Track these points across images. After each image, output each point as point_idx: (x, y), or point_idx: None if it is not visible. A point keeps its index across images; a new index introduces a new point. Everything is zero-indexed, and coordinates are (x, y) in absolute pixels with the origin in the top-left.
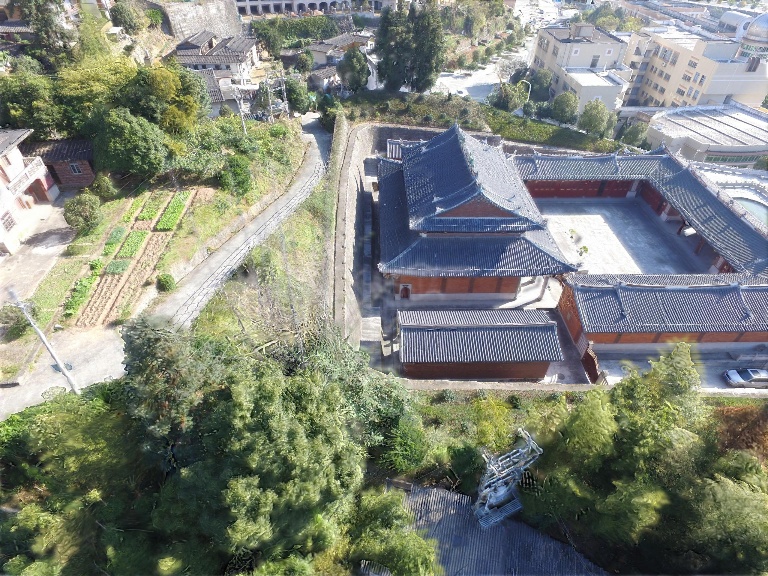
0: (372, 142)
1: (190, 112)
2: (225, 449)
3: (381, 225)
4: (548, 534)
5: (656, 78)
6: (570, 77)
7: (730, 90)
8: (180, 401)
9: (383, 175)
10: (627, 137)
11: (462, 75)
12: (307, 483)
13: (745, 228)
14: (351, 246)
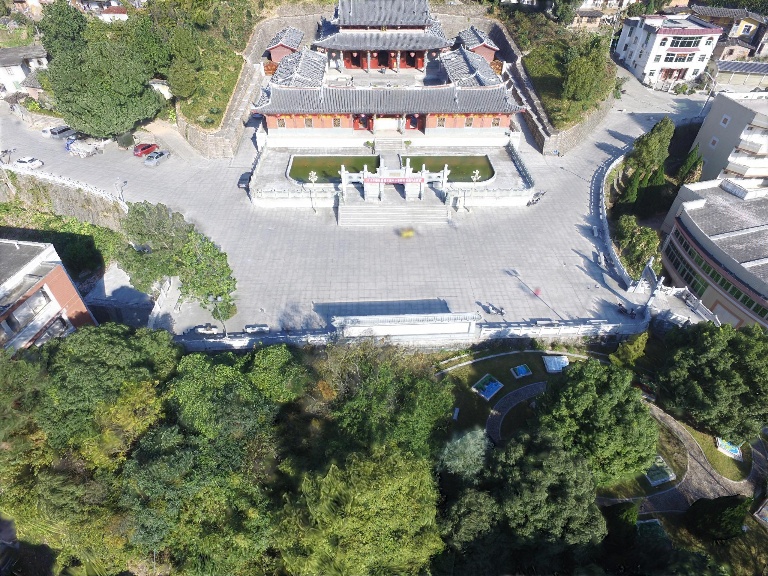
0: (488, 34)
1: None
2: None
3: None
4: None
5: None
6: None
7: None
8: None
9: None
10: None
11: None
12: None
13: None
14: None
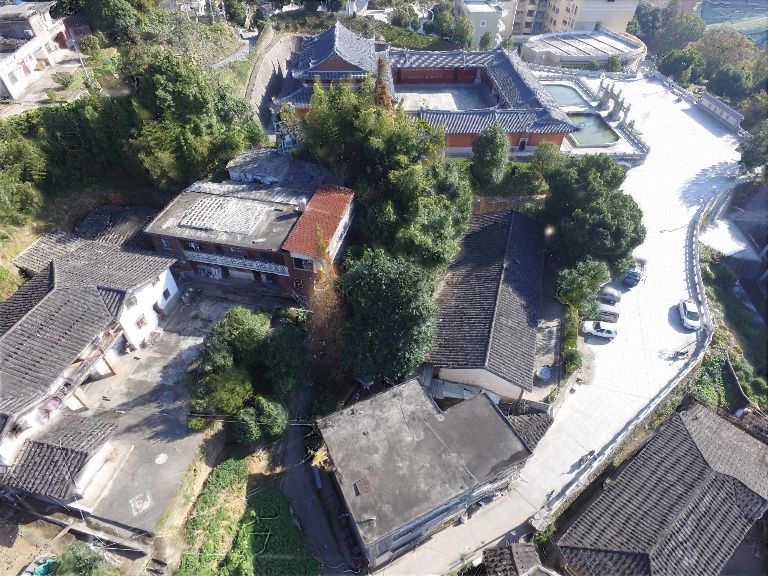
0: (294, 48)
1: None
2: (153, 66)
3: (283, 86)
4: (312, 162)
5: (551, 13)
6: (464, 6)
7: (597, 18)
8: (139, 65)
9: (293, 62)
10: None
11: None
12: (185, 86)
13: (523, 86)
14: (260, 94)
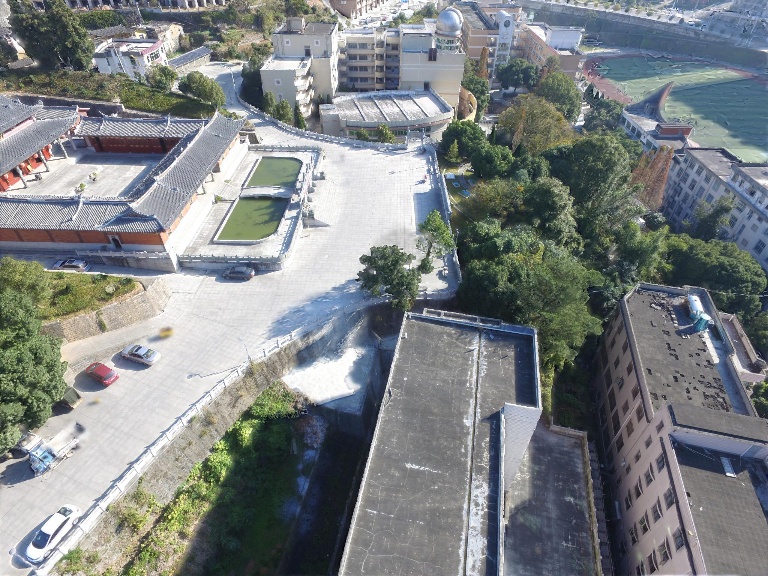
0: None
1: None
2: None
3: None
4: None
5: None
6: None
7: (422, 77)
8: None
9: None
10: (277, 113)
11: (233, 64)
12: None
13: None
14: None
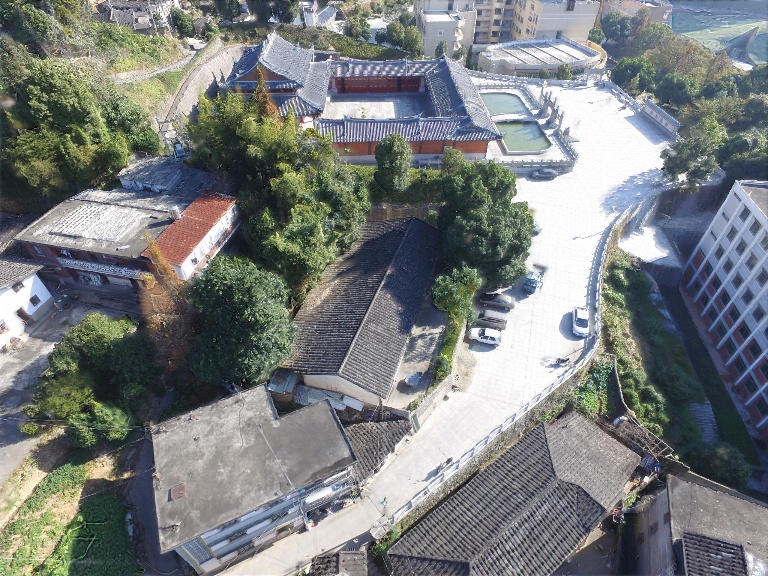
0: None
1: (74, 10)
2: (27, 77)
3: None
4: (204, 170)
5: (517, 22)
6: (423, 16)
7: (557, 27)
8: (19, 76)
9: None
10: None
11: None
12: (61, 96)
13: (455, 95)
14: (191, 104)
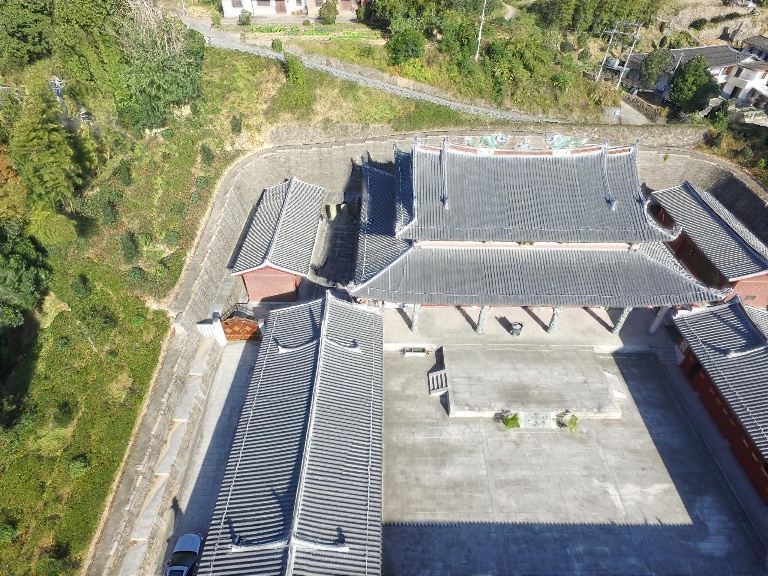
0: (706, 188)
1: None
2: None
3: None
4: None
5: None
6: None
7: None
8: None
9: None
10: None
11: None
12: None
13: None
14: None
